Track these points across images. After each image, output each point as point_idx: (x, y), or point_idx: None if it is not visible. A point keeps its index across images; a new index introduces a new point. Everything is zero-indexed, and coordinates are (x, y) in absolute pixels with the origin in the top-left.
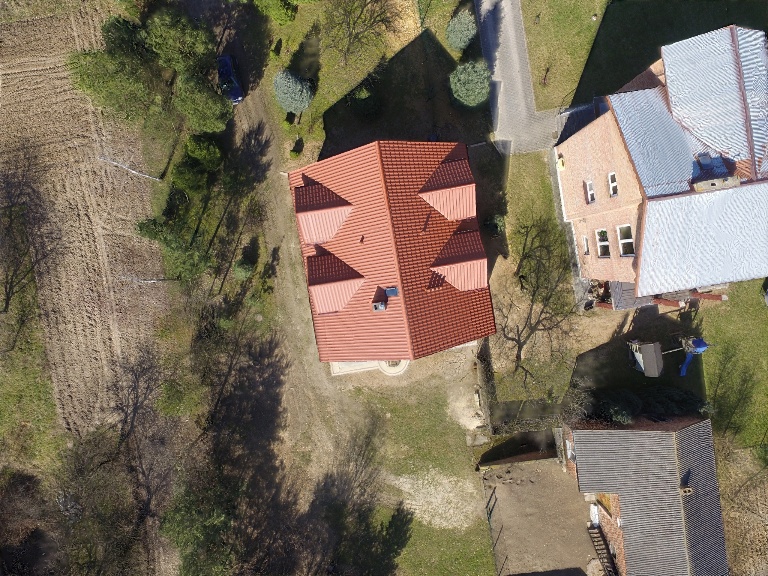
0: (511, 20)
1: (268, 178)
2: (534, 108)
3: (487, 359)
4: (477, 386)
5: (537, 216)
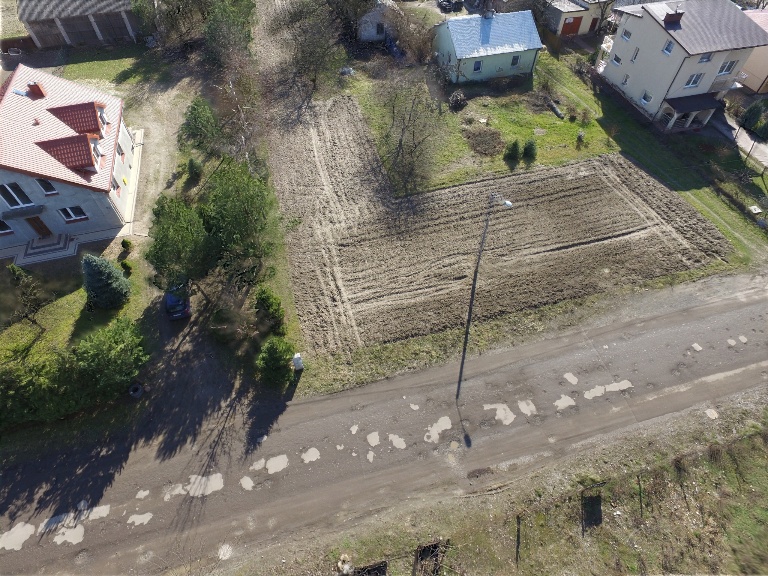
0: None
1: None
2: None
3: None
4: None
5: None
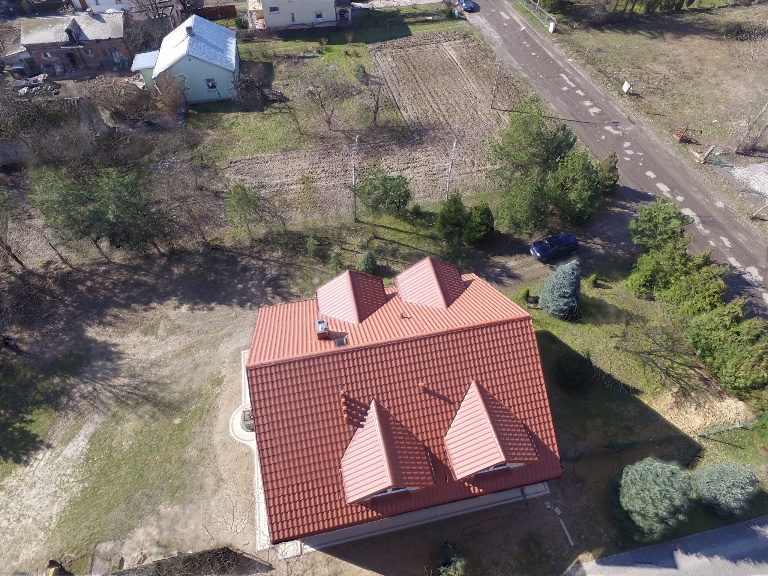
0: None
1: None
2: None
3: (230, 571)
4: None
5: None
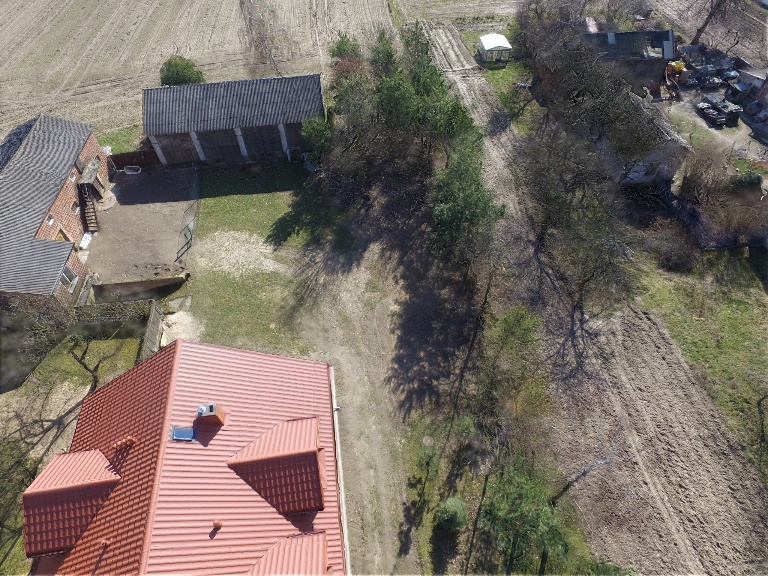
0: None
1: None
2: None
3: None
4: None
5: None
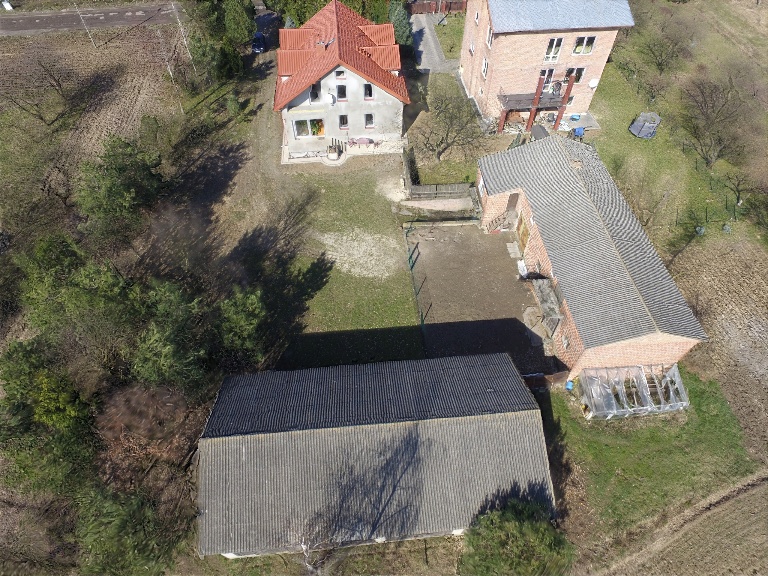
0: (429, 34)
1: (267, 78)
2: (444, 59)
3: (412, 160)
4: (403, 175)
5: (449, 96)
